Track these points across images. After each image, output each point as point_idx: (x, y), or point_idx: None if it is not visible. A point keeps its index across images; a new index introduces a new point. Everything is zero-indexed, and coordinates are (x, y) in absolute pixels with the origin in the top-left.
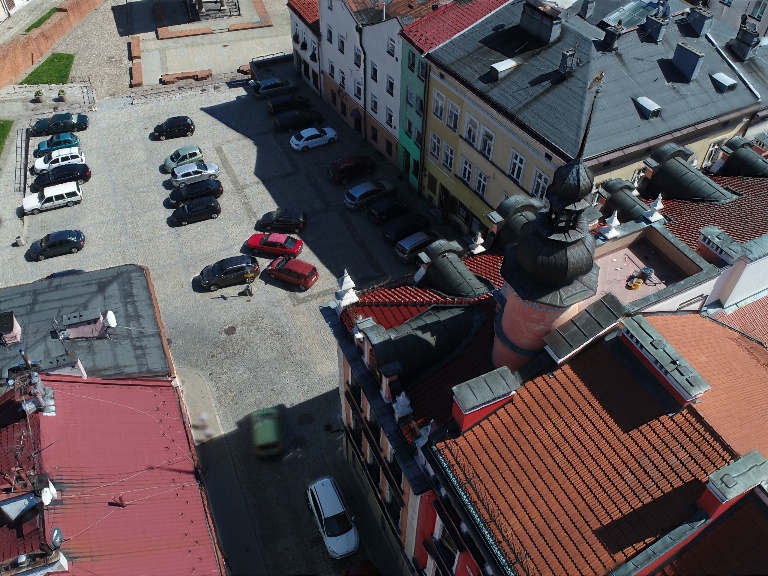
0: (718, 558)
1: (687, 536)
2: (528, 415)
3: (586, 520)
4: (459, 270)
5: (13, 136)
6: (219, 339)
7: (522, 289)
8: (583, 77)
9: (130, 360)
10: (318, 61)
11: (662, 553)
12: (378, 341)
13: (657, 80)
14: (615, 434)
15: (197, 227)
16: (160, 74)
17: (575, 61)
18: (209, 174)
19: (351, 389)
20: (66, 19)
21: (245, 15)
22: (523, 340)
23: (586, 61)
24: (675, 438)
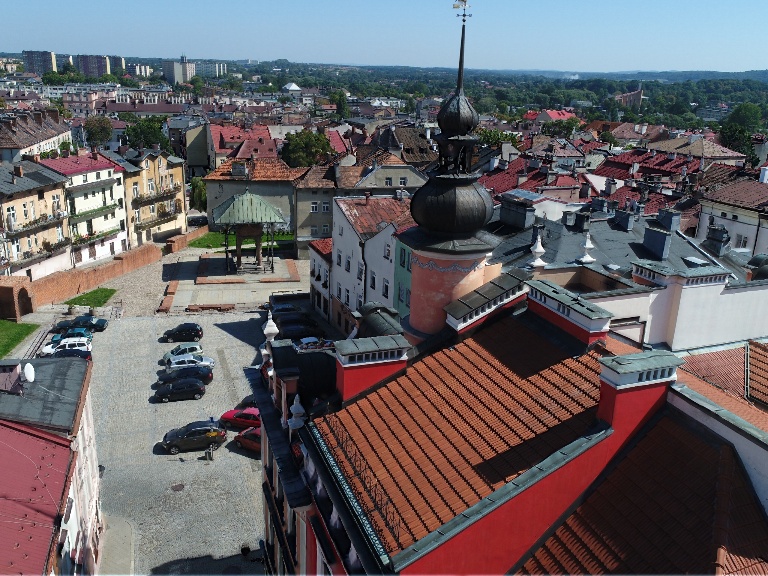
0: (630, 489)
1: (583, 449)
2: (420, 382)
3: (466, 458)
4: (389, 321)
5: (35, 334)
6: (163, 494)
7: (415, 240)
8: (554, 247)
9: (34, 414)
10: (329, 287)
11: (550, 469)
12: (279, 345)
13: (628, 256)
14: (512, 381)
15: (177, 405)
16: (188, 305)
17: (545, 233)
18: (203, 365)
19: (267, 470)
20: (120, 266)
21: (278, 273)
22: (425, 320)
23: (557, 237)
24: (579, 374)
